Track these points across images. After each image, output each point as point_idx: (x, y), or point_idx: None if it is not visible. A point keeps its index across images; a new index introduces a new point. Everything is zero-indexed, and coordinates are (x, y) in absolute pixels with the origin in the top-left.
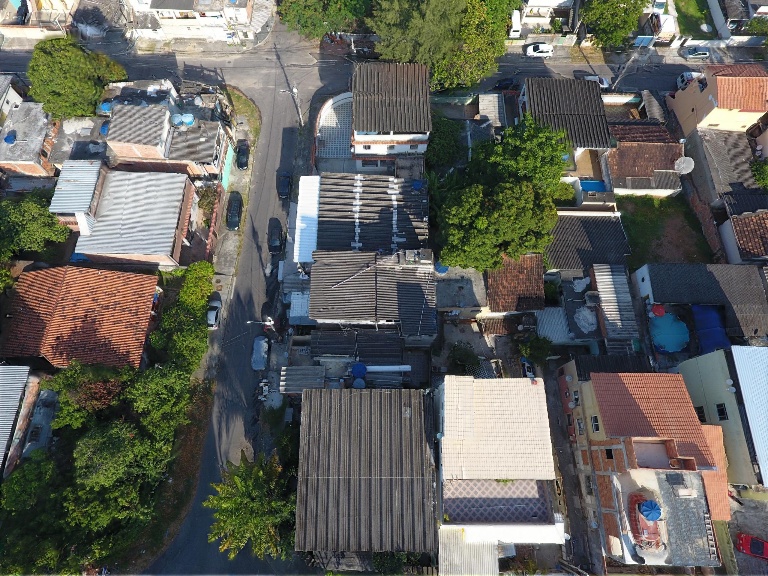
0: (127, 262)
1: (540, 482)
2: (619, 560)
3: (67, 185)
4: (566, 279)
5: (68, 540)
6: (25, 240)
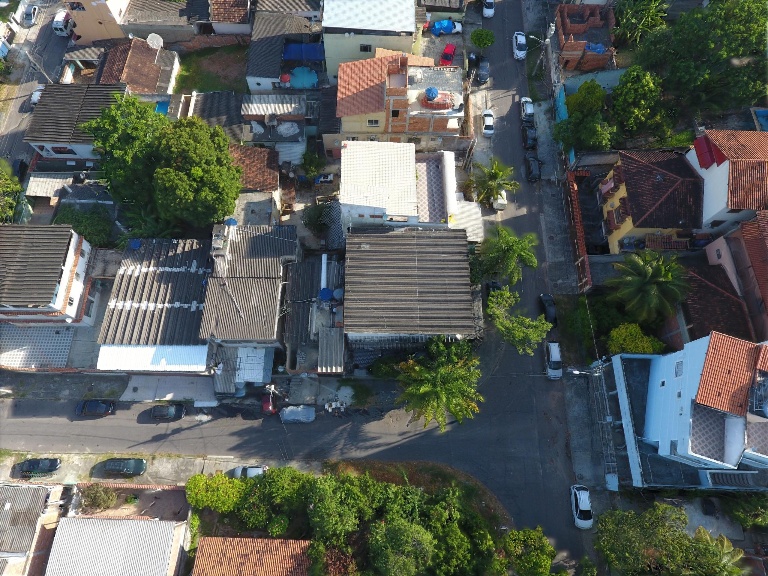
0: None
1: None
2: None
3: None
4: (251, 138)
5: (482, 566)
6: None
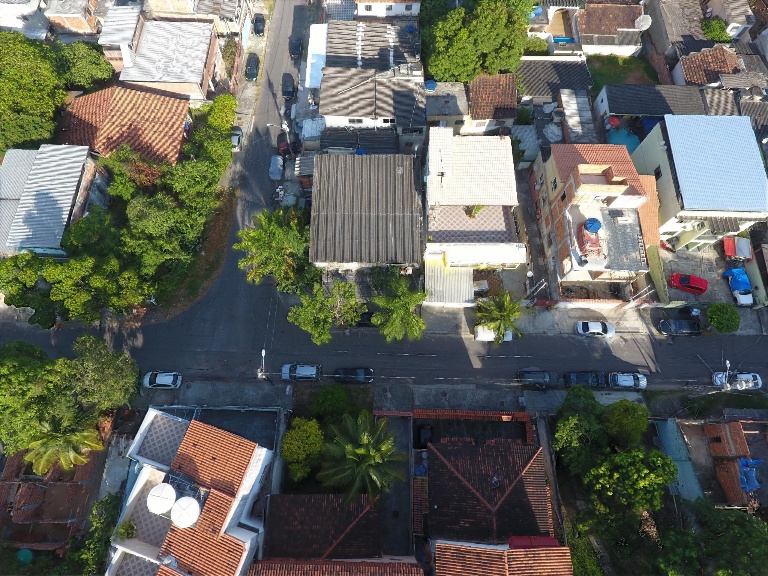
0: (162, 95)
1: (507, 220)
2: (569, 271)
3: (113, 24)
4: (537, 104)
5: (124, 269)
6: (76, 74)
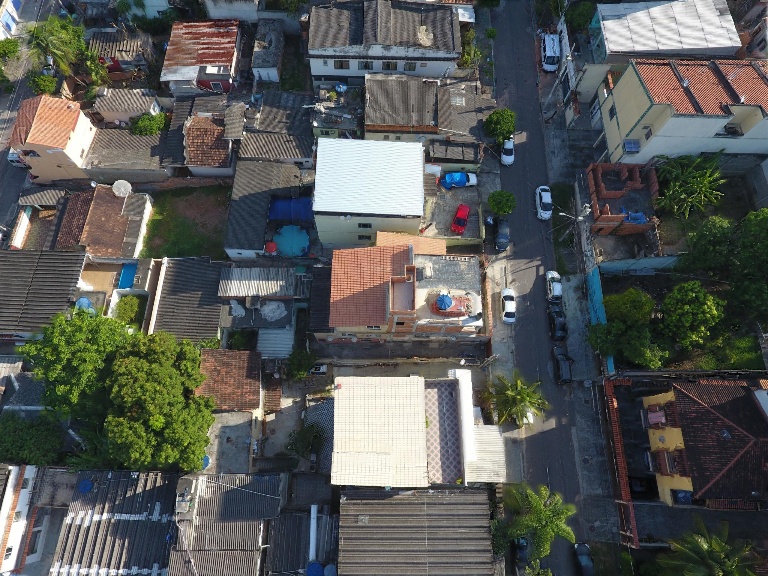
0: None
1: None
2: None
3: None
4: (230, 323)
5: None
6: None
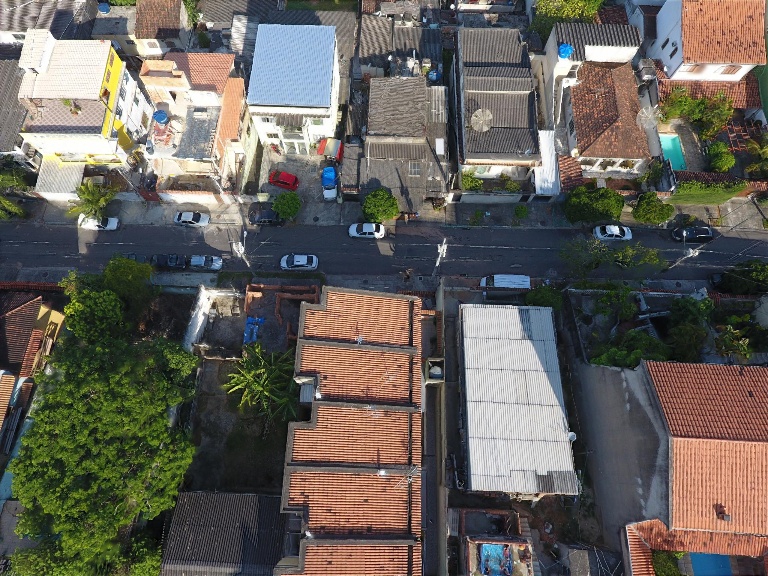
0: None
1: None
2: None
3: None
4: (217, 29)
5: None
6: None
